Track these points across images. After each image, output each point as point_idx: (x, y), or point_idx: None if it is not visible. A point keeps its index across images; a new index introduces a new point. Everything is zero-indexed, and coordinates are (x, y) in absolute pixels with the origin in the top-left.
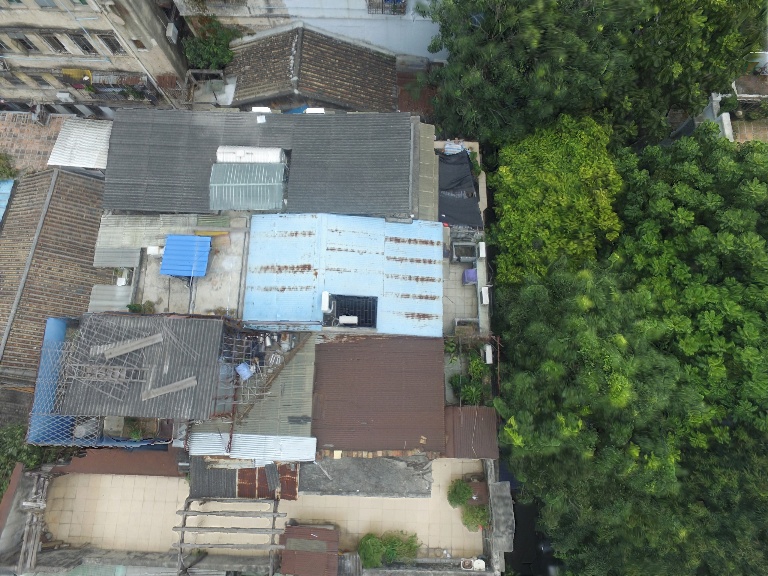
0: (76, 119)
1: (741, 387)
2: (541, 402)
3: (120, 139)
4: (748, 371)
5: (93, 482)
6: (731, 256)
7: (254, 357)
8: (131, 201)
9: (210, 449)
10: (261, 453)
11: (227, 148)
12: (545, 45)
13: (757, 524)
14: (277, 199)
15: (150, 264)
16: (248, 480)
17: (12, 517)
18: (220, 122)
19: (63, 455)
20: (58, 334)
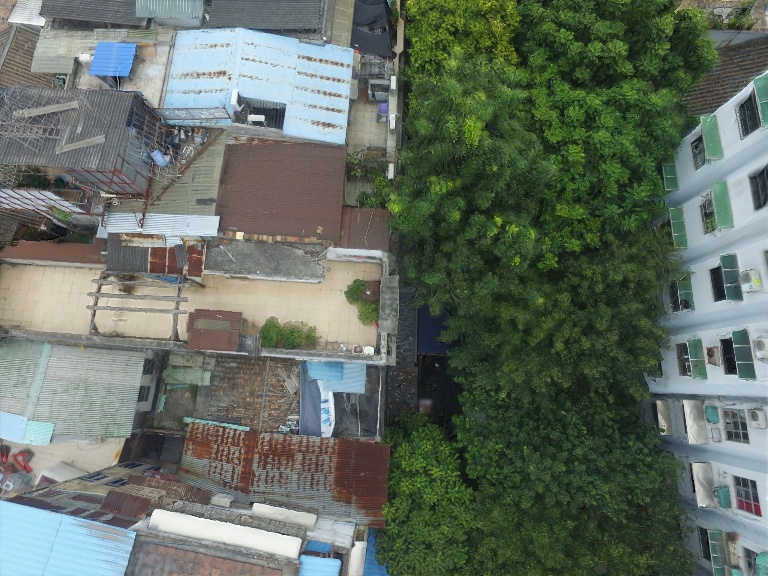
0: None
1: (604, 184)
2: (417, 180)
3: None
4: (601, 153)
5: (26, 275)
6: (603, 69)
7: (167, 144)
8: (66, 11)
9: (125, 226)
10: (170, 229)
11: None
12: None
13: (620, 320)
14: (198, 10)
15: (83, 75)
16: (159, 258)
17: None
18: None
19: None
20: None
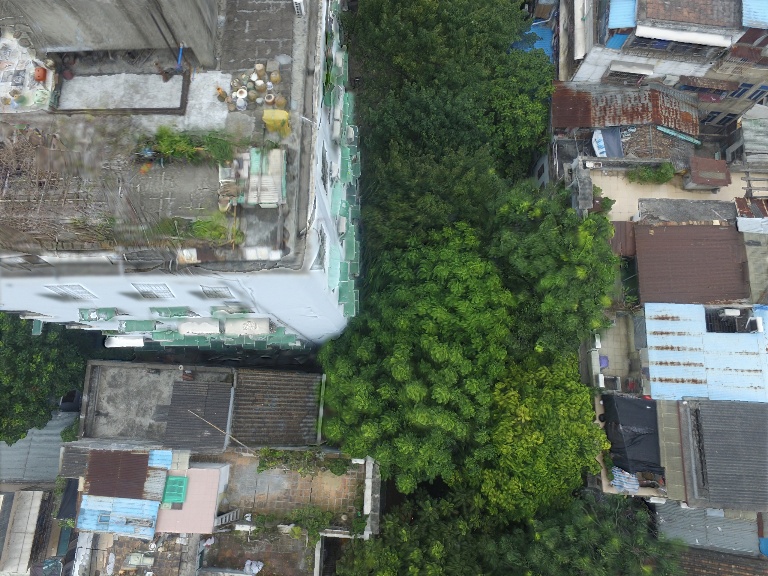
0: None
1: None
2: (596, 245)
3: None
4: None
5: None
6: None
7: None
8: None
9: None
10: None
11: None
12: (596, 568)
13: None
14: None
15: None
16: None
17: None
18: None
19: None
20: None
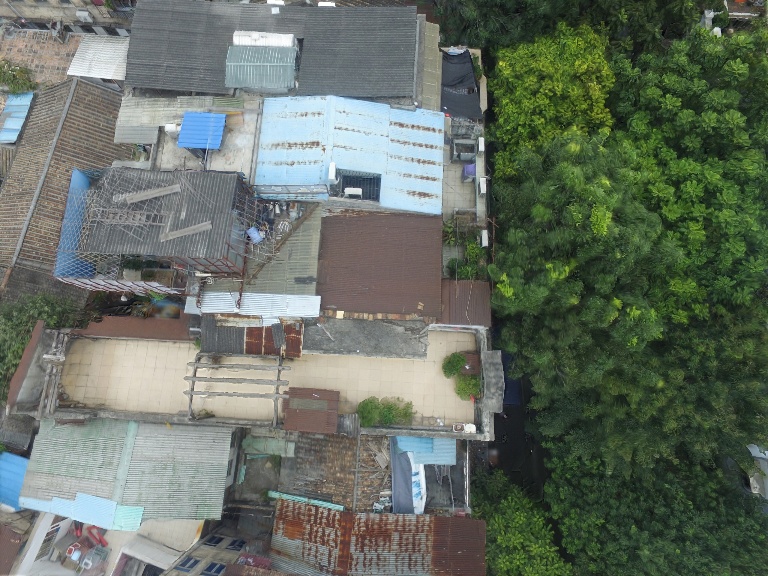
0: (95, 35)
1: (720, 258)
2: (532, 260)
3: (142, 24)
4: (725, 232)
5: (108, 350)
6: (715, 138)
7: (264, 221)
8: (151, 80)
9: (221, 306)
10: (268, 309)
11: (243, 32)
12: None
13: (732, 395)
14: (289, 79)
15: (167, 144)
16: (255, 338)
17: (33, 370)
18: (236, 12)
19: (80, 324)
20: (82, 187)
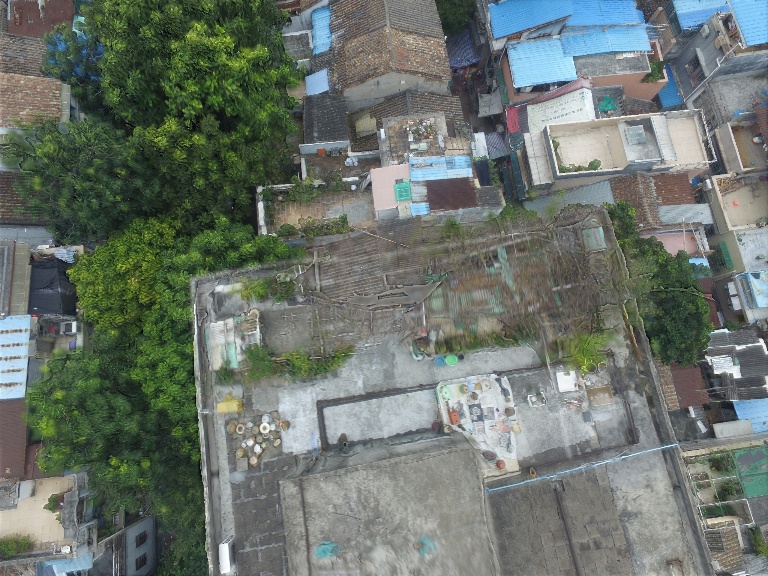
0: None
1: None
2: (53, 437)
3: None
4: None
5: None
6: None
7: None
8: None
9: None
10: None
11: None
12: (79, 185)
13: None
14: None
15: None
16: None
17: None
18: None
19: None
20: None
